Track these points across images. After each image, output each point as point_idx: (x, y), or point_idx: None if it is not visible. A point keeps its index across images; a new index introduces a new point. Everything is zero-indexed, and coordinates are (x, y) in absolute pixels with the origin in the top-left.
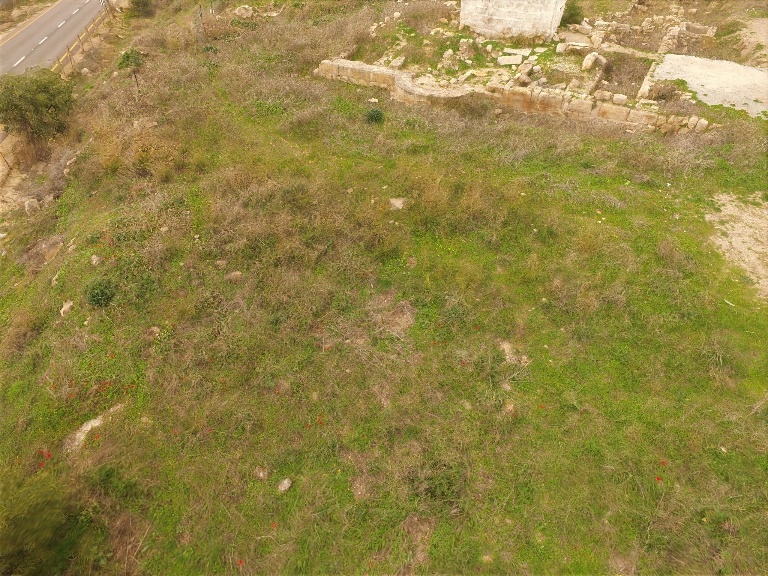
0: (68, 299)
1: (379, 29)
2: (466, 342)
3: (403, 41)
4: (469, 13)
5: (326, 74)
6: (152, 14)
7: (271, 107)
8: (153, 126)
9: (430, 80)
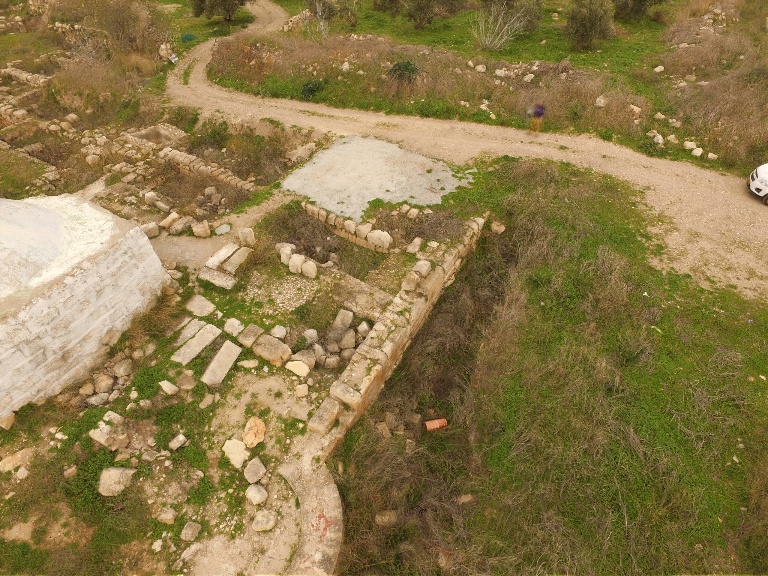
0: None
1: None
2: None
3: None
4: (6, 391)
5: None
6: None
7: None
8: None
9: (221, 553)
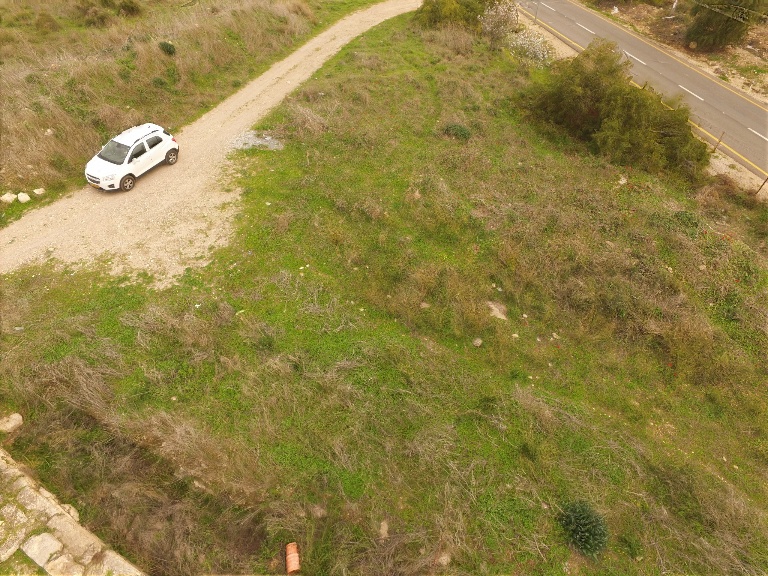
0: None
1: None
2: None
3: None
4: None
5: None
6: None
7: None
8: None
9: None
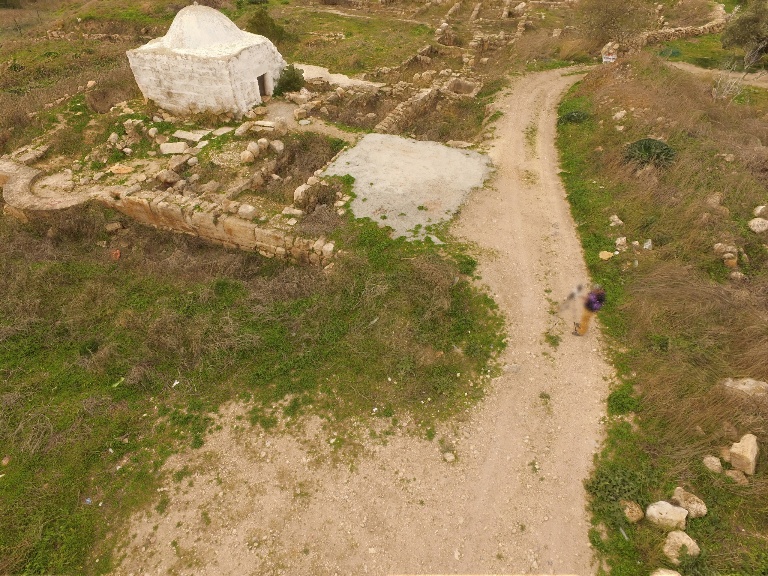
0: None
1: None
2: None
3: (61, 123)
4: (146, 85)
5: None
6: None
7: None
8: None
9: (62, 179)
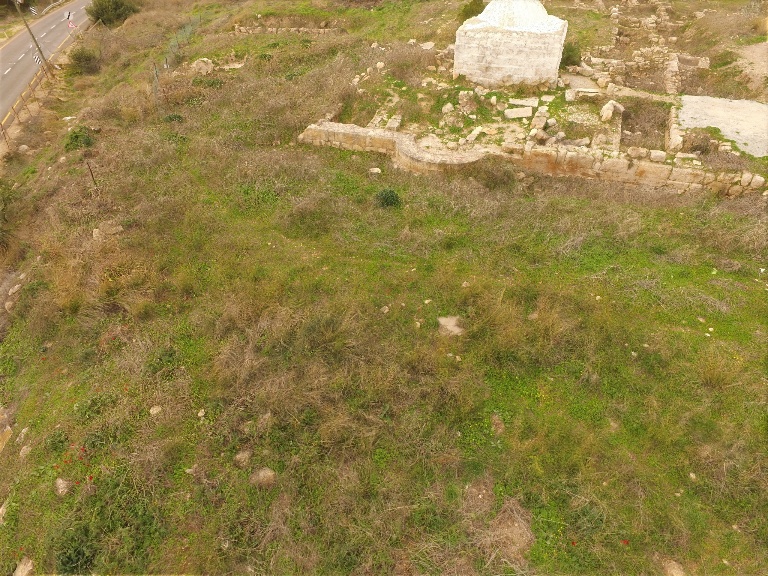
0: (24, 556)
1: (363, 82)
2: (617, 569)
3: (395, 96)
4: (464, 62)
5: (313, 140)
6: (96, 70)
7: (261, 194)
8: (118, 232)
9: (435, 141)
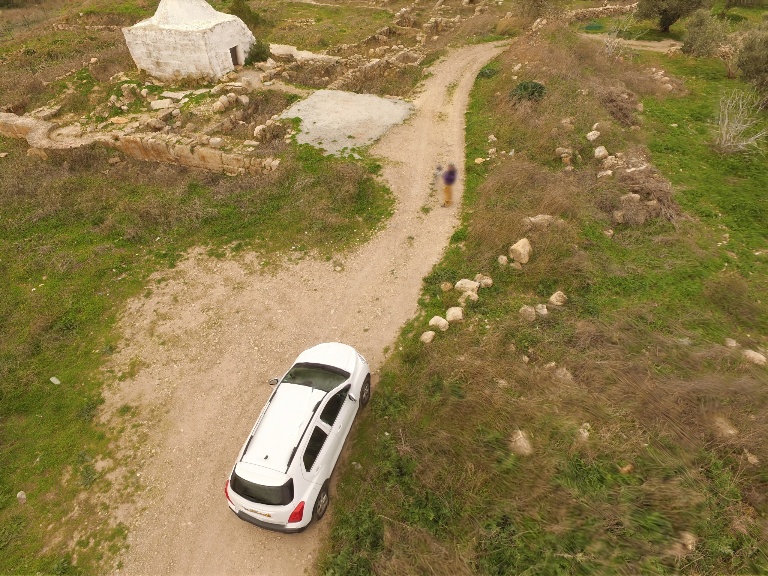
0: None
1: None
2: None
3: (70, 89)
4: (139, 57)
5: None
6: None
7: None
8: None
9: (72, 129)
